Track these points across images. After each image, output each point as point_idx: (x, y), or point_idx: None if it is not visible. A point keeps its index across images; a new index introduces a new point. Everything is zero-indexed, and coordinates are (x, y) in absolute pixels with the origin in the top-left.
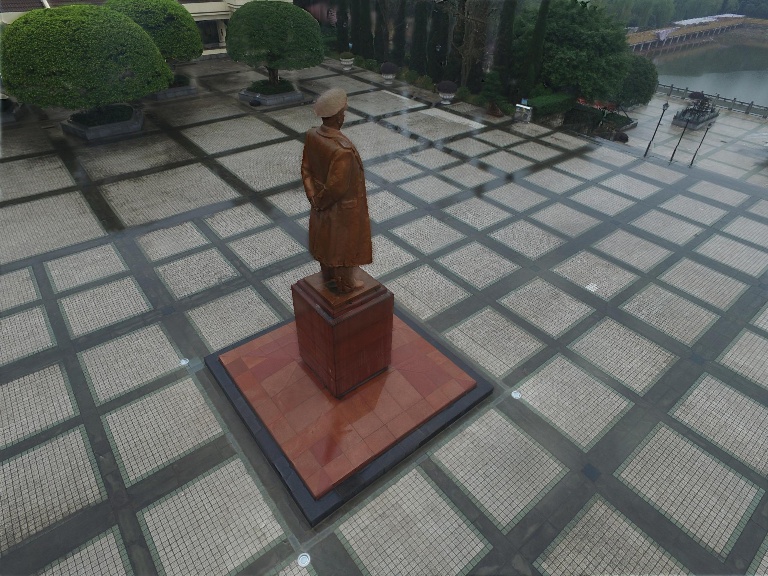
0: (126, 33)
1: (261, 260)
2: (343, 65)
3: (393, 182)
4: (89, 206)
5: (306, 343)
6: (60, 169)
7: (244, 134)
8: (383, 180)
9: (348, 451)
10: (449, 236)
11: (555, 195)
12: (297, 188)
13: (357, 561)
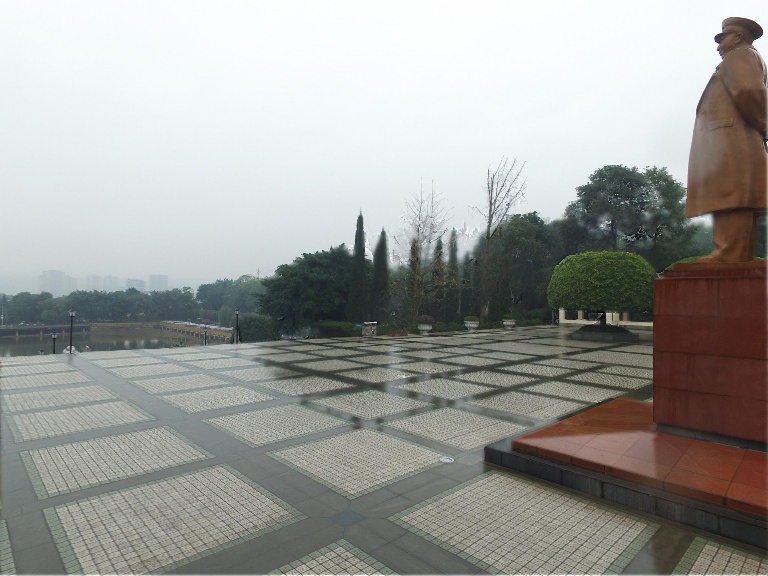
0: None
1: None
2: None
3: None
4: None
5: None
6: None
7: None
8: None
9: None
10: (291, 411)
11: None
12: None
13: None
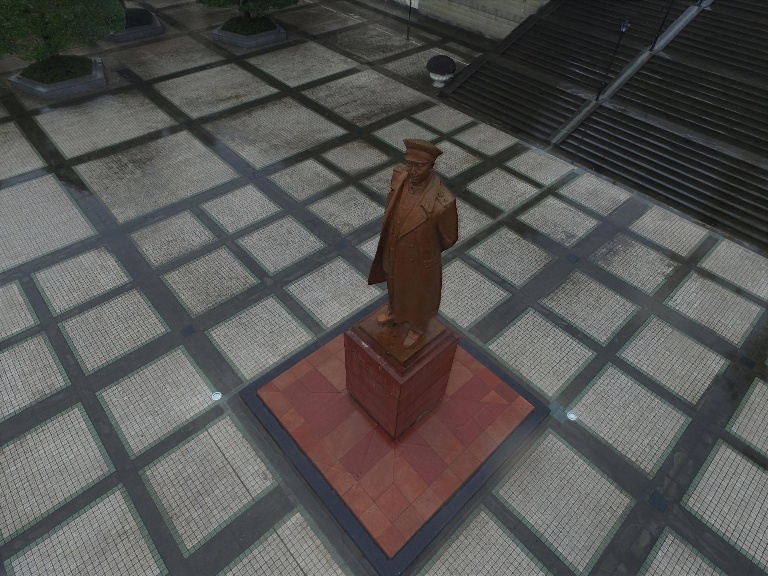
0: None
1: None
2: None
3: None
4: None
5: None
6: None
7: None
8: None
9: None
10: None
11: None
12: None
13: None
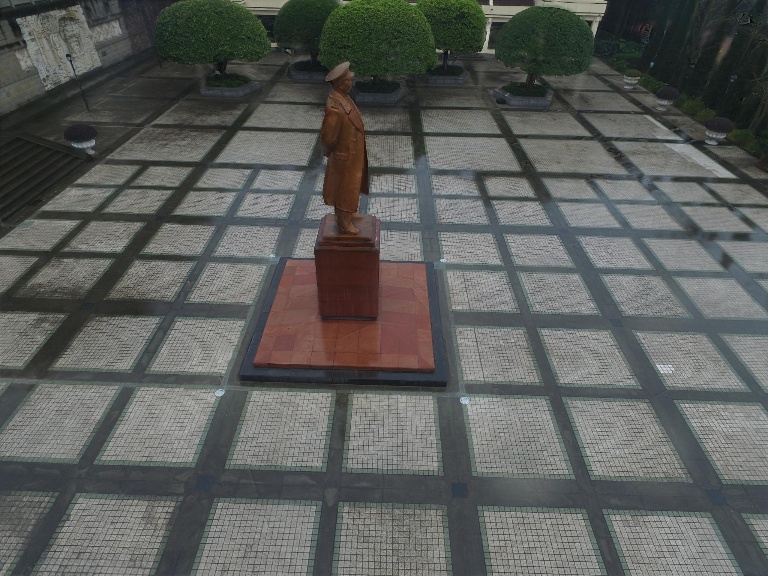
0: (406, 23)
1: (380, 216)
2: (625, 83)
3: (555, 197)
4: (315, 145)
5: None
6: (322, 117)
7: (466, 123)
8: (547, 193)
9: (296, 352)
10: (556, 259)
11: (740, 271)
12: (463, 176)
13: (243, 414)
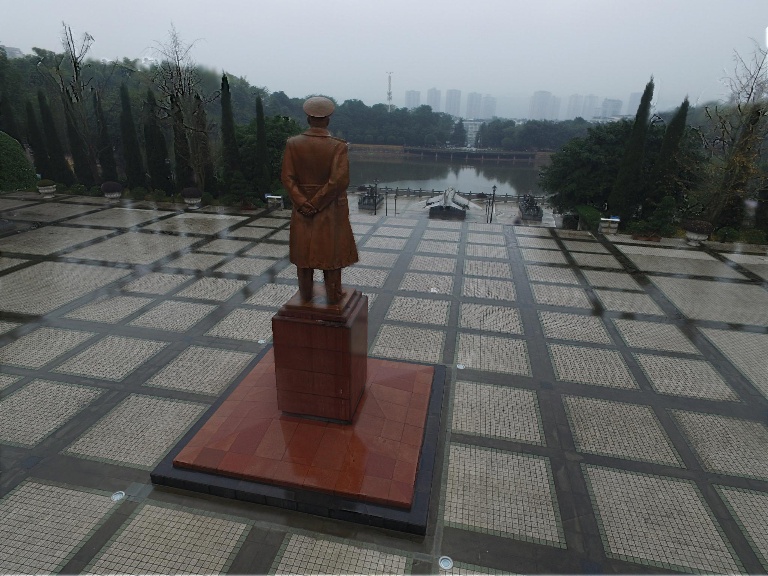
0: None
1: (120, 368)
2: (42, 194)
3: (206, 269)
4: None
5: (295, 382)
6: None
7: None
8: (193, 270)
9: (399, 456)
10: None
11: None
12: (96, 299)
13: (484, 531)
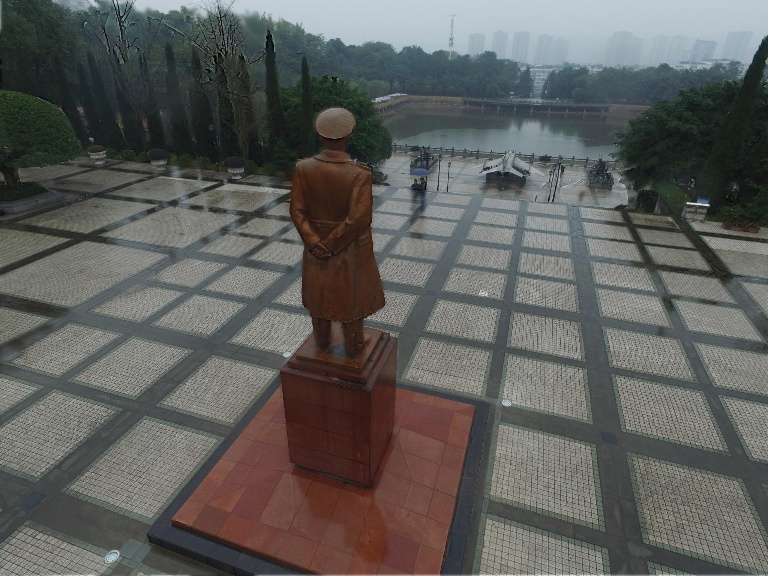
0: None
1: (138, 382)
2: (93, 159)
3: (240, 256)
4: None
5: (308, 439)
6: None
7: (2, 250)
8: (227, 257)
9: (423, 539)
10: None
11: (396, 232)
12: (127, 290)
13: None
